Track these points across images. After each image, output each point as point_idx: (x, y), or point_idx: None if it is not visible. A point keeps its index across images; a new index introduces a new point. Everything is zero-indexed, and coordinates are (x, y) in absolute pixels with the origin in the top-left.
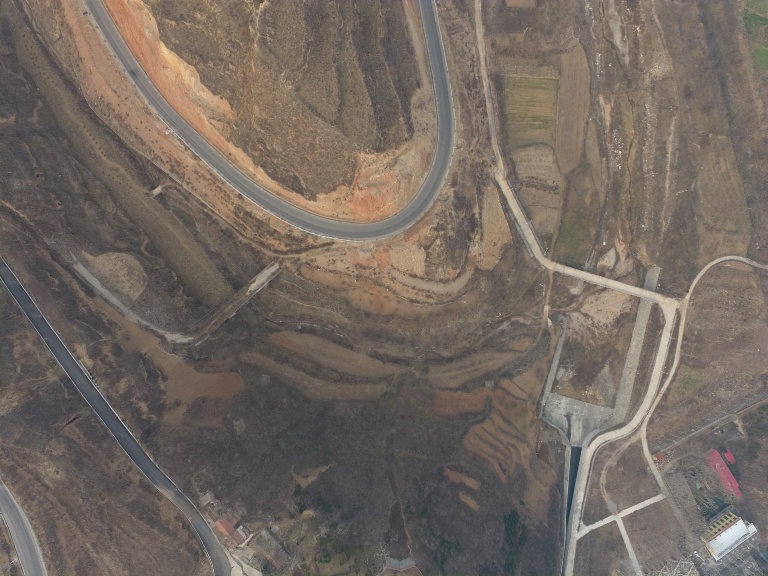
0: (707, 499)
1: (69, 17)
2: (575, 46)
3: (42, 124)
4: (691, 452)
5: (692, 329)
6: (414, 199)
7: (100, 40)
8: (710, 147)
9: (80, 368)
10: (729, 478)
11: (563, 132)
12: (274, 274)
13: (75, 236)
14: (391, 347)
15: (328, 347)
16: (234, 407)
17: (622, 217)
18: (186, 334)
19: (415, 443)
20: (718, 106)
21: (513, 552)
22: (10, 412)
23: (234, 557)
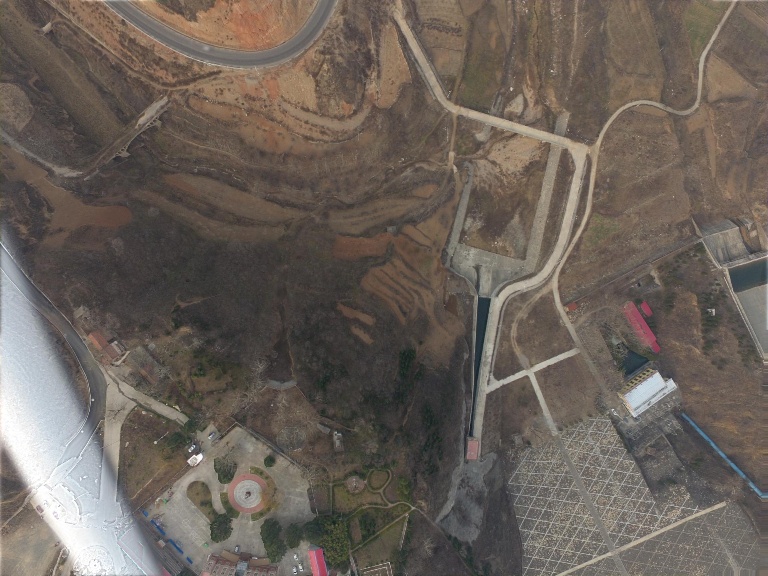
0: (618, 346)
1: None
2: None
3: None
4: (606, 305)
5: (604, 176)
6: (303, 28)
7: None
8: None
9: None
10: (645, 330)
11: None
12: (163, 107)
13: None
14: (290, 192)
15: (225, 190)
16: (118, 235)
17: (530, 62)
18: (74, 168)
19: (309, 281)
20: None
21: (405, 384)
22: None
23: (110, 374)
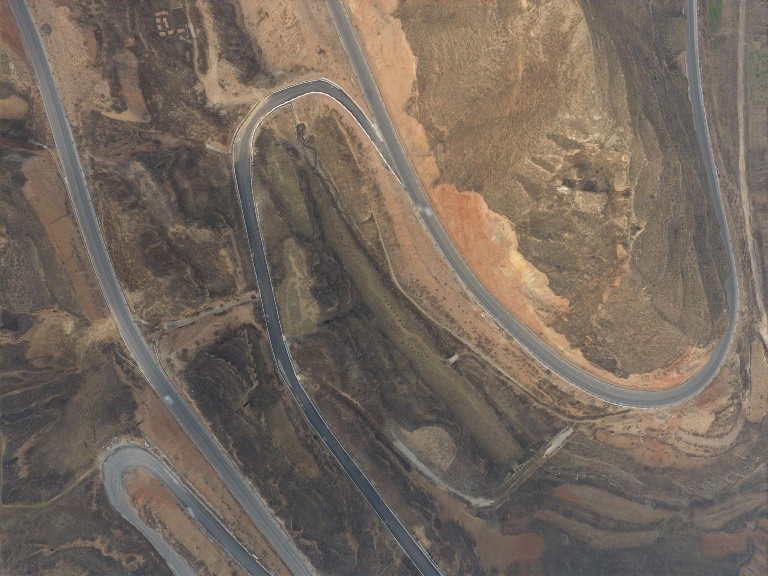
0: None
1: (390, 207)
2: None
3: (353, 303)
4: None
5: None
6: None
7: (422, 230)
8: None
9: (420, 549)
10: None
11: None
12: (569, 438)
13: (391, 412)
14: (660, 493)
15: (604, 497)
16: (545, 571)
17: None
18: (488, 498)
19: None
20: None
21: None
22: None
23: None
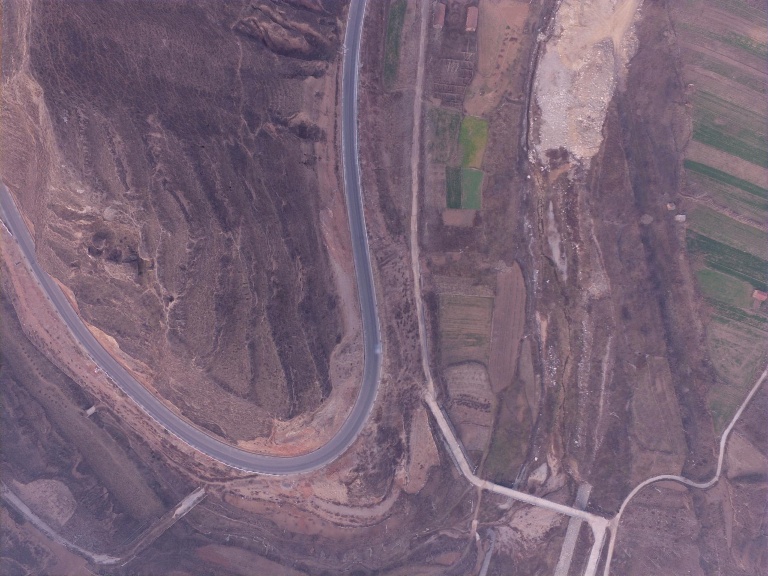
0: None
1: (6, 258)
2: (511, 266)
3: None
4: None
5: None
6: (338, 433)
7: (34, 283)
8: (646, 367)
9: None
10: None
11: (497, 351)
12: (200, 499)
13: (8, 463)
14: (318, 560)
15: (255, 560)
16: None
17: (555, 432)
18: (113, 555)
19: None
20: (656, 327)
21: None
22: None
23: None
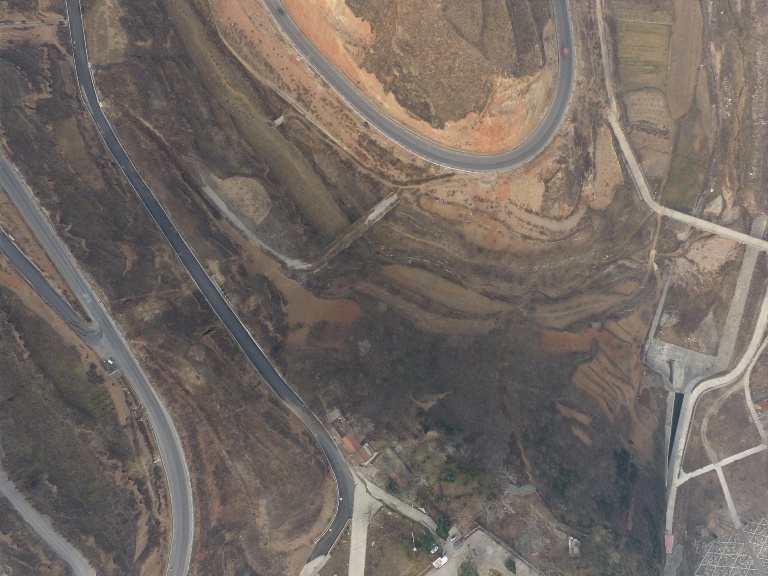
0: None
1: None
2: None
3: (173, 51)
4: None
5: None
6: (534, 134)
7: None
8: None
9: (212, 283)
10: None
11: (675, 77)
12: (393, 205)
13: (204, 159)
14: (499, 285)
15: (438, 282)
16: (354, 331)
17: (730, 165)
18: (305, 261)
19: (526, 378)
20: None
21: (626, 487)
22: (153, 318)
23: (358, 474)
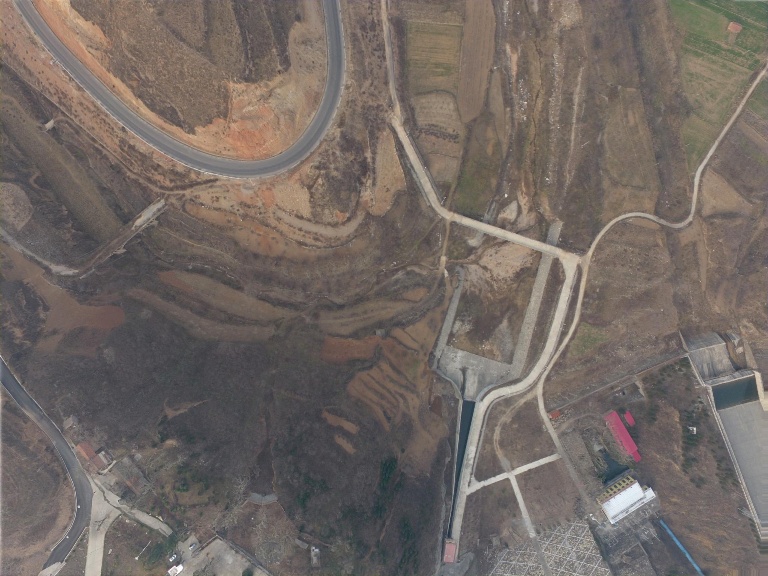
0: (598, 458)
1: None
2: None
3: None
4: (589, 412)
5: (594, 286)
6: (300, 138)
7: None
8: (618, 99)
9: None
10: (627, 440)
11: (465, 80)
12: (160, 210)
13: None
14: (282, 291)
15: (218, 288)
16: (110, 338)
17: (526, 169)
18: (71, 266)
19: (296, 385)
20: (628, 57)
21: (385, 496)
22: None
23: (96, 482)
